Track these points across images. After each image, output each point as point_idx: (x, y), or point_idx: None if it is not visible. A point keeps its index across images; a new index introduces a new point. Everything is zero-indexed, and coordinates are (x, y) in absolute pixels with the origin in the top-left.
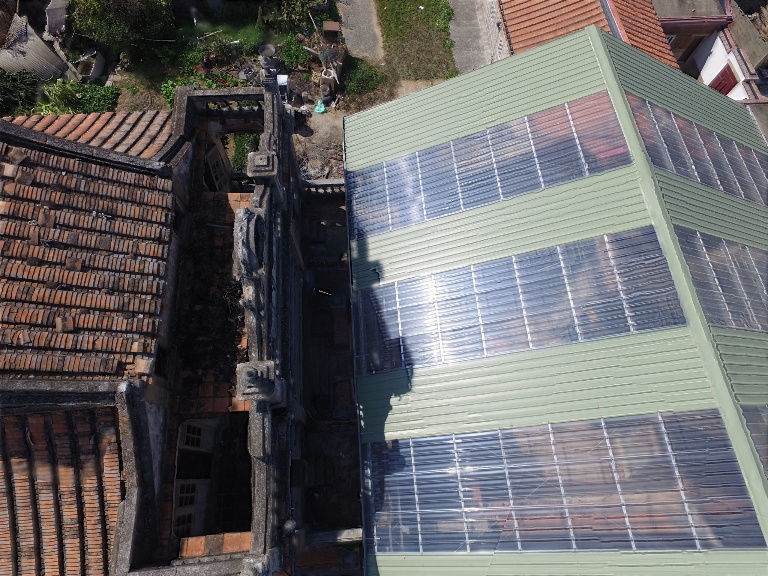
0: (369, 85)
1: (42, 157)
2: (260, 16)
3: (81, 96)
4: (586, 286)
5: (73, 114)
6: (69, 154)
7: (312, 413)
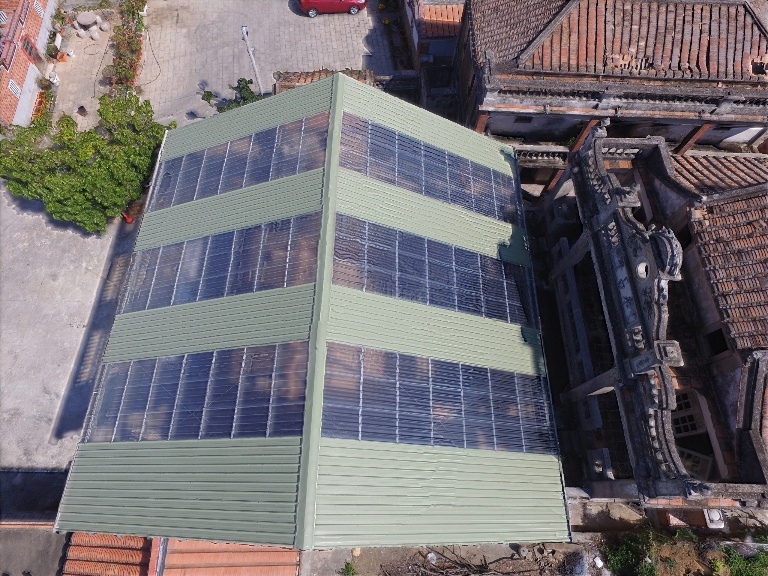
0: None
1: None
2: None
3: None
4: (386, 261)
5: None
6: None
7: (542, 287)
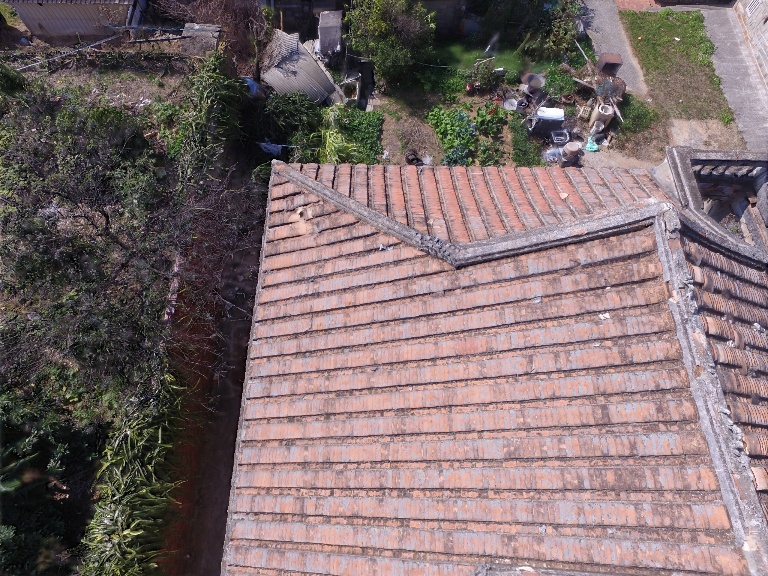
0: (644, 123)
1: (707, 254)
2: (523, 42)
3: (349, 121)
4: None
5: (345, 141)
6: (715, 248)
7: None
